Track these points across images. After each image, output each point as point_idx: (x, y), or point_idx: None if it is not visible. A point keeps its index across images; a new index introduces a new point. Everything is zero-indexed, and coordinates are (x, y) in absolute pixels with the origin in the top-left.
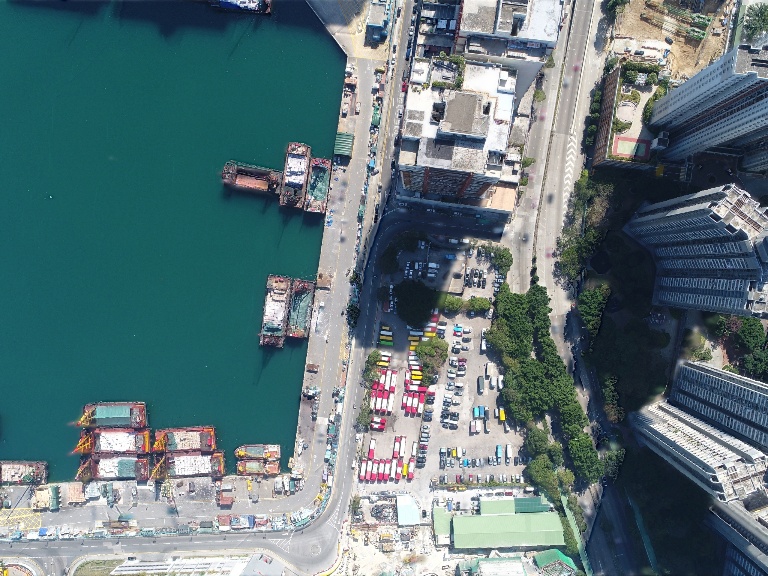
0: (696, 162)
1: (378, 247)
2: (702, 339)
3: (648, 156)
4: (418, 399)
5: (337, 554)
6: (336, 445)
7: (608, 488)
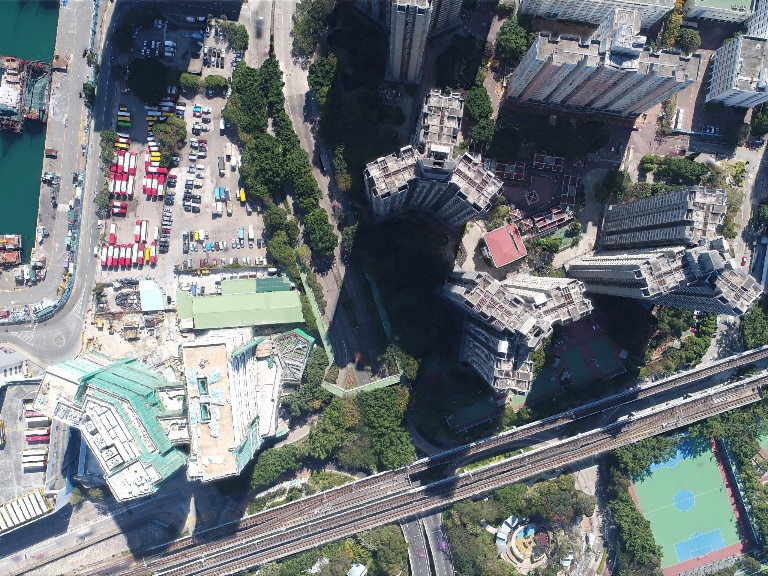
0: None
1: (115, 27)
2: None
3: None
4: (158, 181)
5: (82, 345)
6: (76, 231)
7: (350, 268)
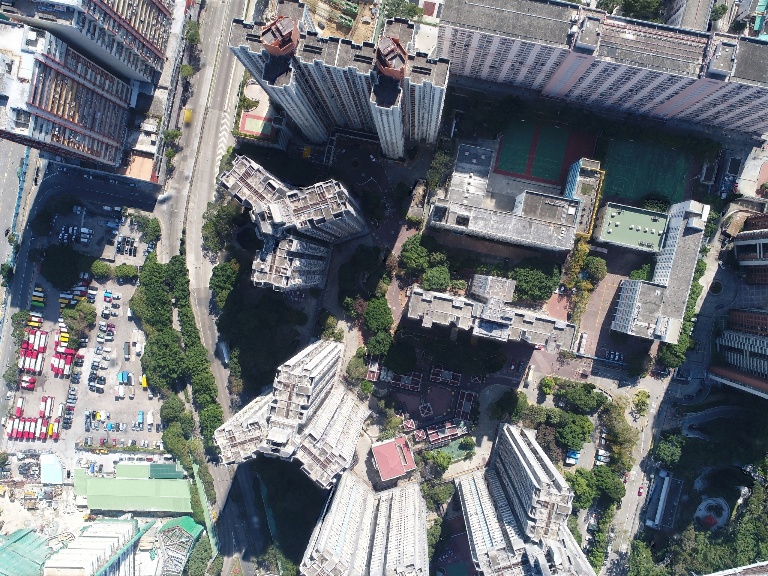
0: (341, 146)
1: (37, 209)
2: (330, 318)
3: (273, 135)
4: (65, 361)
5: None
6: None
7: None
